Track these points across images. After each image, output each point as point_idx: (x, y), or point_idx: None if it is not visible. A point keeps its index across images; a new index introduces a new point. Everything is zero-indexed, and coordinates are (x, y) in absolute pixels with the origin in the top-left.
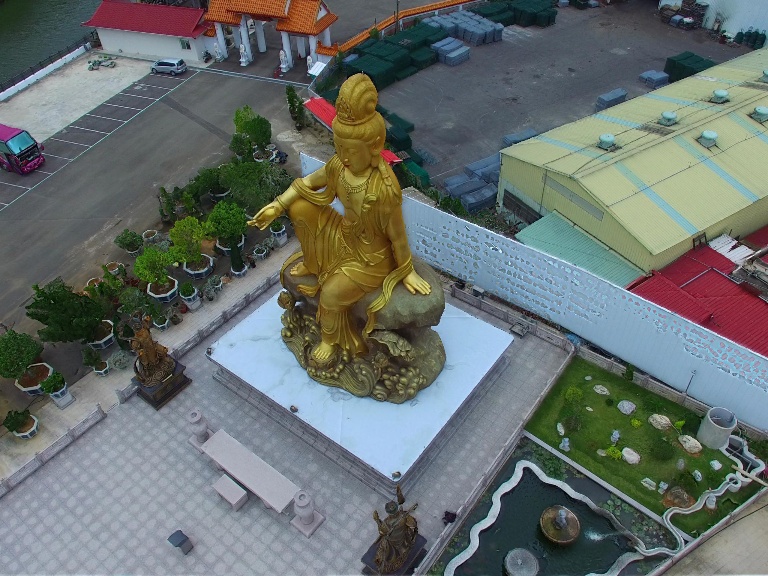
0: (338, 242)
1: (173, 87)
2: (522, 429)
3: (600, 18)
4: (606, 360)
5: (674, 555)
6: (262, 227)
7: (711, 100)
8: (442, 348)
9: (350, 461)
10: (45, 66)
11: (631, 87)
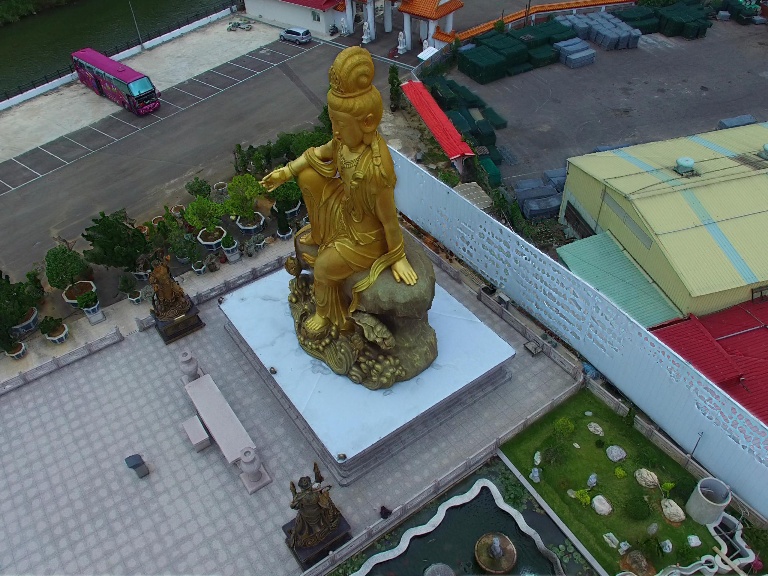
0: (339, 216)
1: (293, 55)
2: (496, 447)
3: (761, 36)
4: (613, 399)
5: None
6: (270, 189)
7: None
8: (433, 345)
9: (313, 434)
10: (191, 22)
11: None
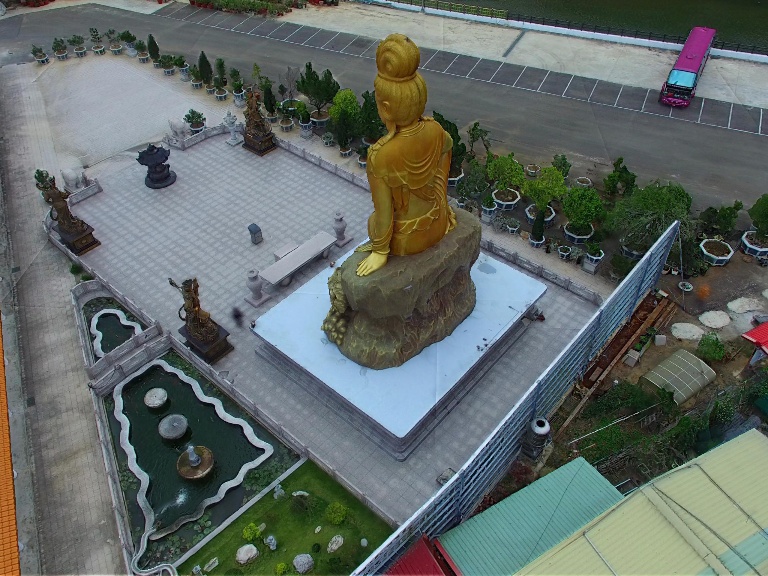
0: None
1: None
2: None
3: None
4: None
5: None
6: None
7: None
8: (377, 356)
9: None
10: None
11: None
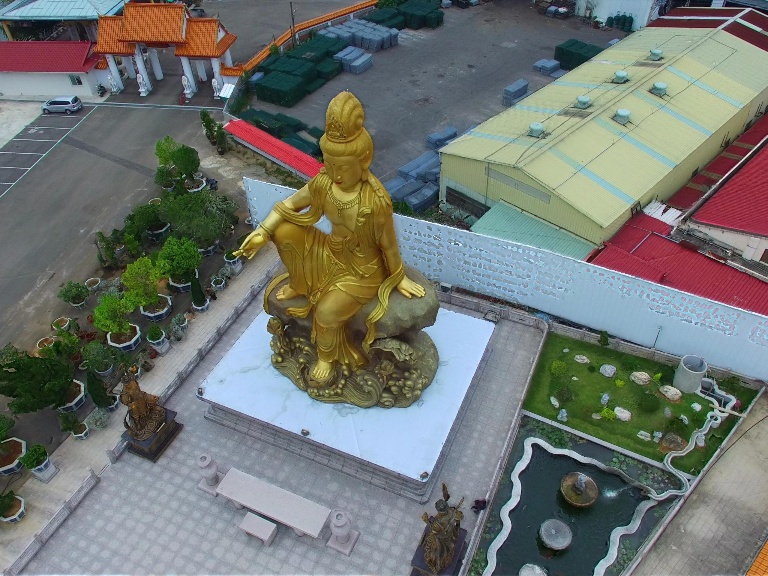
0: (327, 259)
1: (72, 126)
2: (521, 409)
3: (483, 15)
4: (578, 331)
5: (684, 494)
6: (250, 256)
7: (614, 81)
8: (434, 346)
9: (370, 472)
10: None
11: (528, 77)
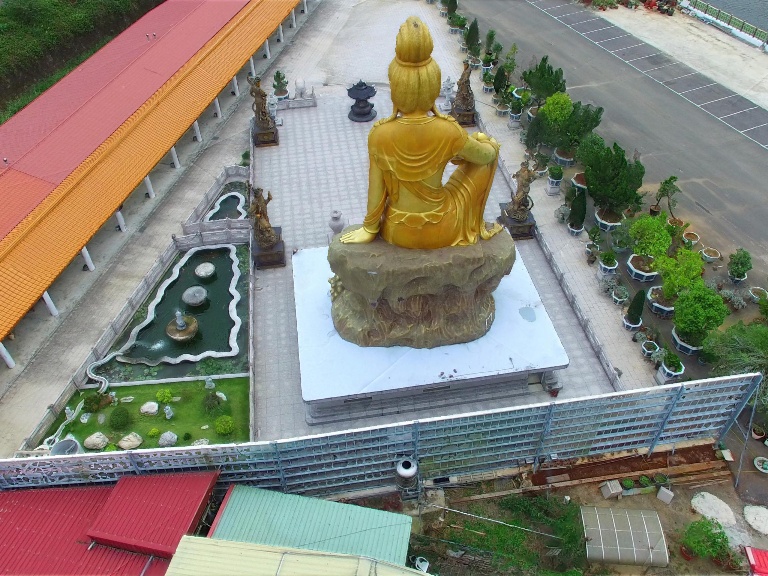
0: None
1: None
2: None
3: None
4: None
5: None
6: None
7: None
8: None
9: None
10: None
11: None
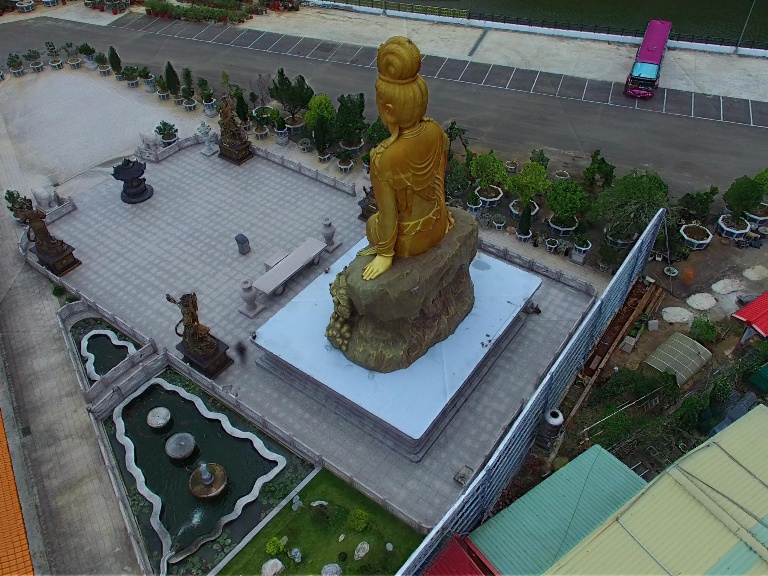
0: None
1: None
2: None
3: None
4: None
5: None
6: None
7: None
8: (385, 360)
9: None
10: None
11: None
